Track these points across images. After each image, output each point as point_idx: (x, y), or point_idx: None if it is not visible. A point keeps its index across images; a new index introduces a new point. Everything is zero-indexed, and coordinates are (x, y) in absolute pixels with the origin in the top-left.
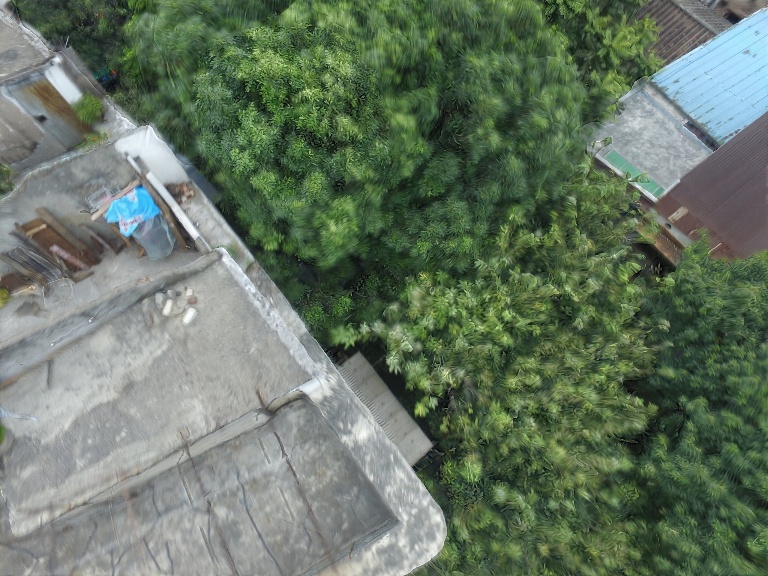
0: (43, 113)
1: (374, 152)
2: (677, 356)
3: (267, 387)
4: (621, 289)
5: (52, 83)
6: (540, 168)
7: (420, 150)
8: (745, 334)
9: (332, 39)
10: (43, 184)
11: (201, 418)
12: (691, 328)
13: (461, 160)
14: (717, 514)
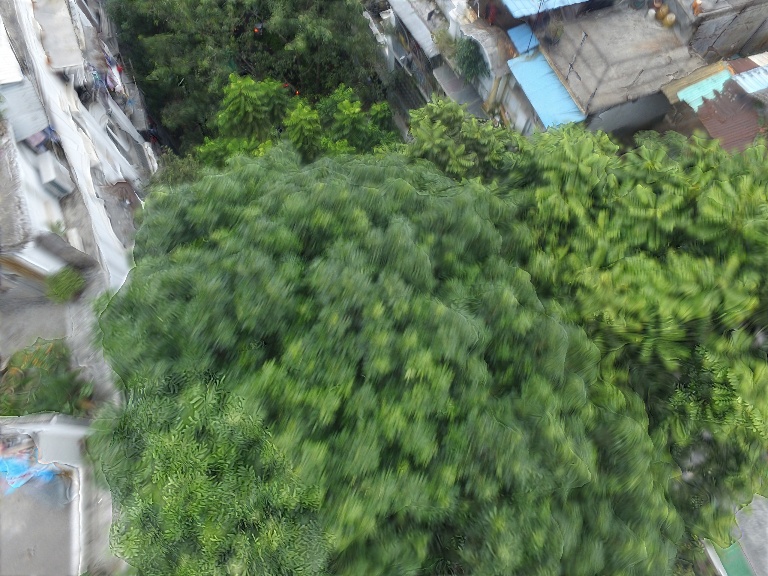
0: (16, 273)
1: None
2: None
3: None
4: None
5: (25, 258)
6: None
7: None
8: None
9: (286, 478)
10: None
11: None
12: None
13: None
14: None
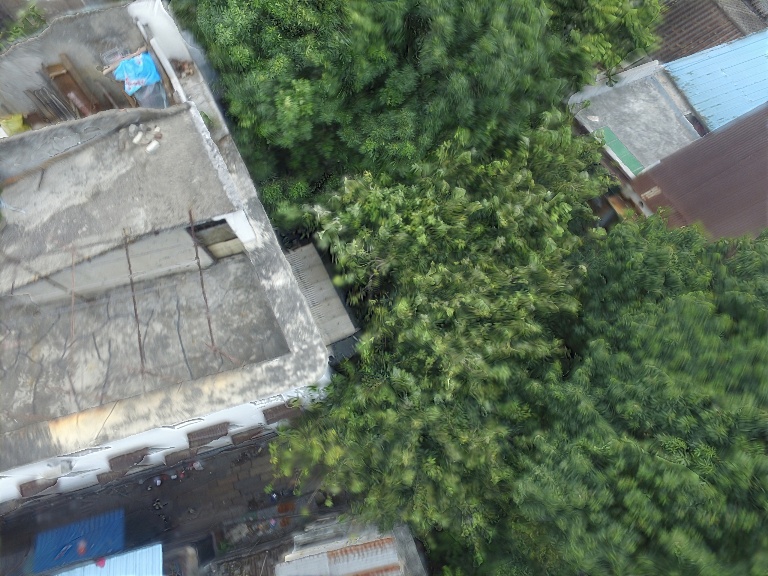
0: None
1: (333, 45)
2: (605, 311)
3: (198, 209)
4: (552, 227)
5: None
6: (488, 94)
7: (382, 58)
8: (665, 294)
9: None
10: (66, 31)
11: (142, 222)
12: (618, 282)
13: (418, 74)
14: (588, 434)
